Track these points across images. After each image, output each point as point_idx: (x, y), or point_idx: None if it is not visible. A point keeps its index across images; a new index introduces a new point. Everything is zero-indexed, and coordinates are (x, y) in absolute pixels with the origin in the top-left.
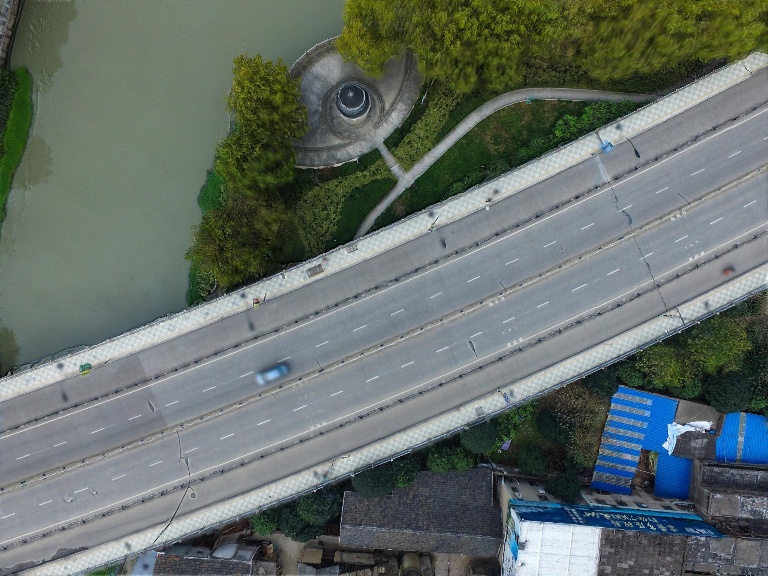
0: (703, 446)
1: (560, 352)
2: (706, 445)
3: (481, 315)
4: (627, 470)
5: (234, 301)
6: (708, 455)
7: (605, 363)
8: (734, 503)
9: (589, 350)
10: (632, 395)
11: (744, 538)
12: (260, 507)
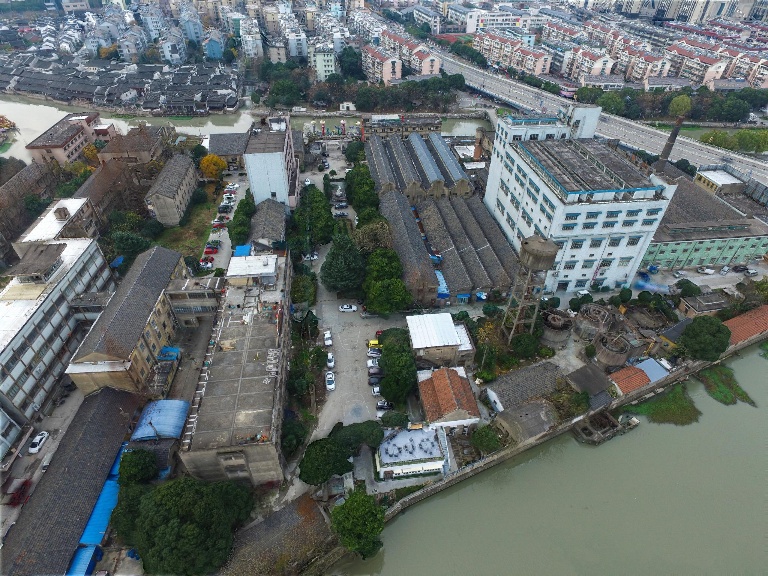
0: None
1: None
2: None
3: (762, 178)
4: None
5: (699, 144)
6: None
7: None
8: None
9: None
10: None
11: None
12: None
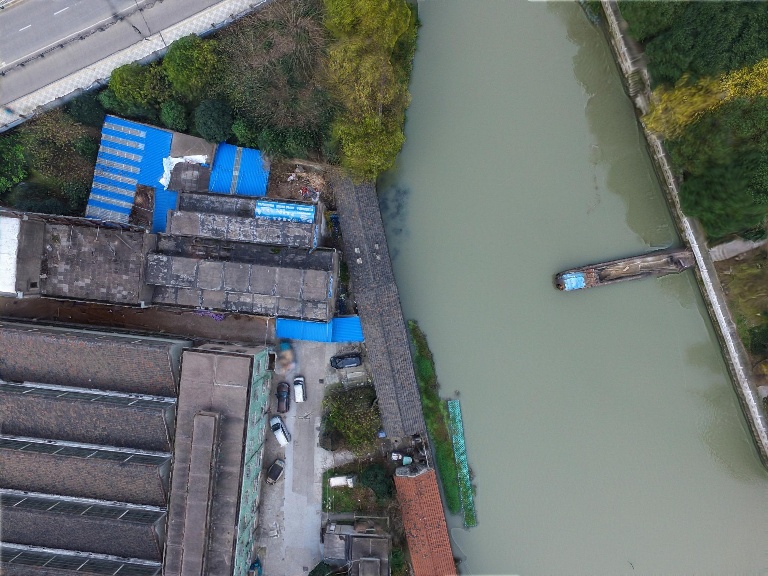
0: (195, 179)
1: (44, 77)
2: (198, 178)
3: None
4: (124, 206)
5: None
6: (201, 189)
7: (87, 88)
8: (194, 221)
9: (72, 75)
10: (124, 126)
11: (208, 260)
12: None
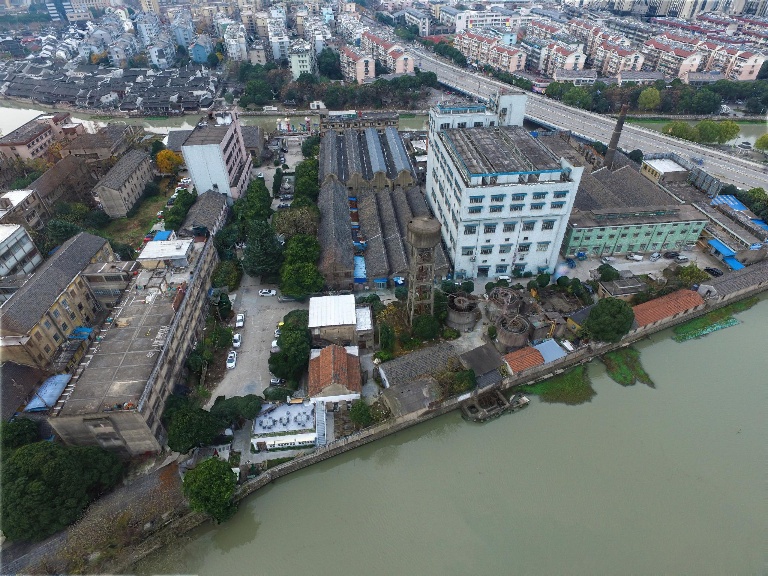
0: None
1: None
2: None
3: None
4: None
5: None
6: None
7: None
8: None
9: None
10: (734, 199)
11: None
12: (602, 143)
